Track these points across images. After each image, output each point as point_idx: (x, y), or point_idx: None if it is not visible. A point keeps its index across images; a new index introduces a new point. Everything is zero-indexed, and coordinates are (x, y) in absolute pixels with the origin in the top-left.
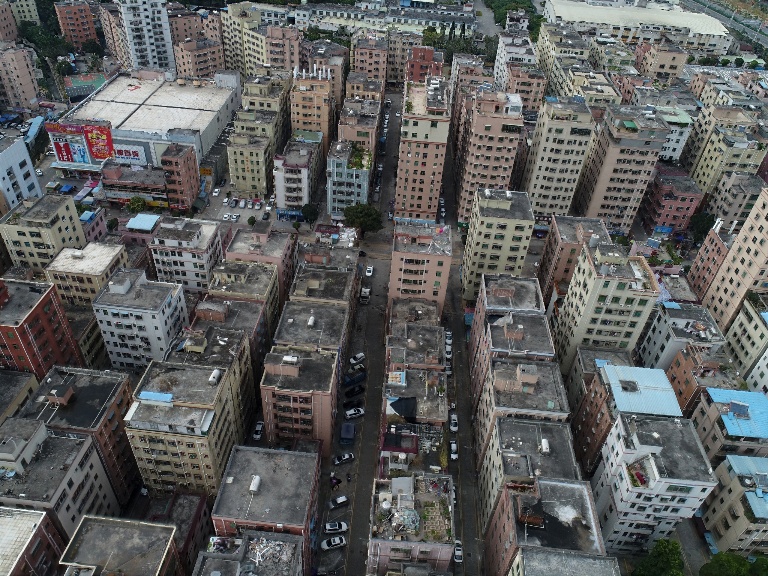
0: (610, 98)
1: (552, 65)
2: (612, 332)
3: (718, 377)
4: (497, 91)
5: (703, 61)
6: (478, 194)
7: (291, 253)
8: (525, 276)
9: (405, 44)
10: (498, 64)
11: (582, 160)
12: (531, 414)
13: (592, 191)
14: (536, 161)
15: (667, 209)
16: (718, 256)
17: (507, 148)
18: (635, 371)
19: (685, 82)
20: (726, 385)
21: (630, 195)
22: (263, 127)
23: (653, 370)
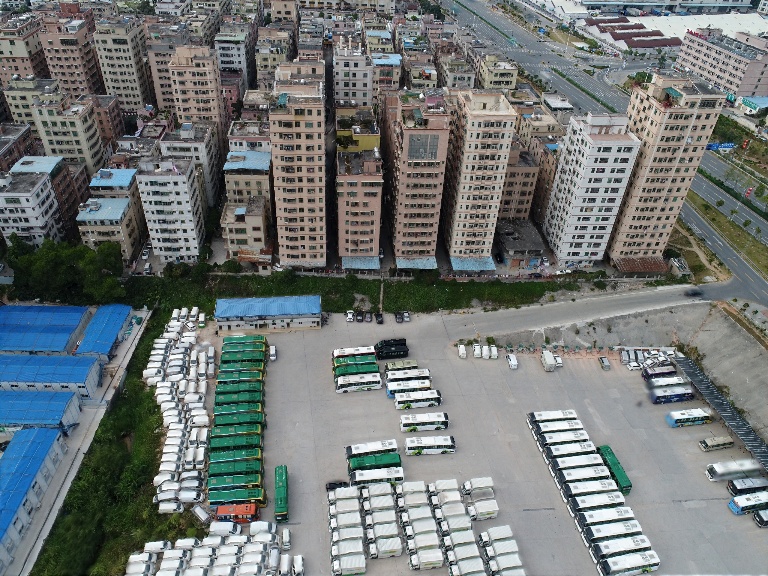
0: (193, 28)
1: None
2: (68, 150)
3: None
4: None
5: None
6: None
7: None
8: None
9: (95, 10)
10: None
11: (132, 64)
12: None
13: None
14: None
15: None
16: None
17: (72, 58)
18: None
19: None
20: None
21: None
22: None
23: (56, 157)
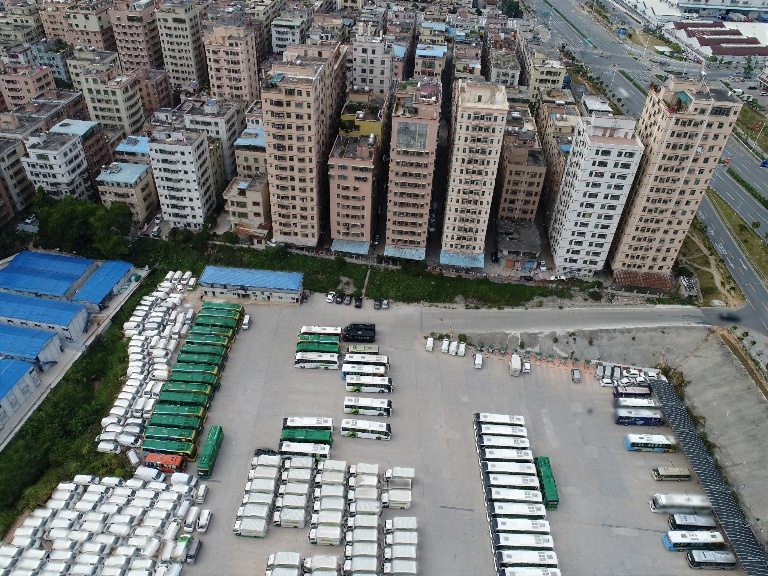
0: (254, 12)
1: None
2: (110, 117)
3: None
4: None
5: (449, 12)
6: None
7: None
8: None
9: None
10: None
11: (189, 42)
12: (4, 137)
13: None
14: None
15: None
16: None
17: (136, 34)
18: (80, 121)
19: None
20: None
21: None
22: (15, 34)
23: None
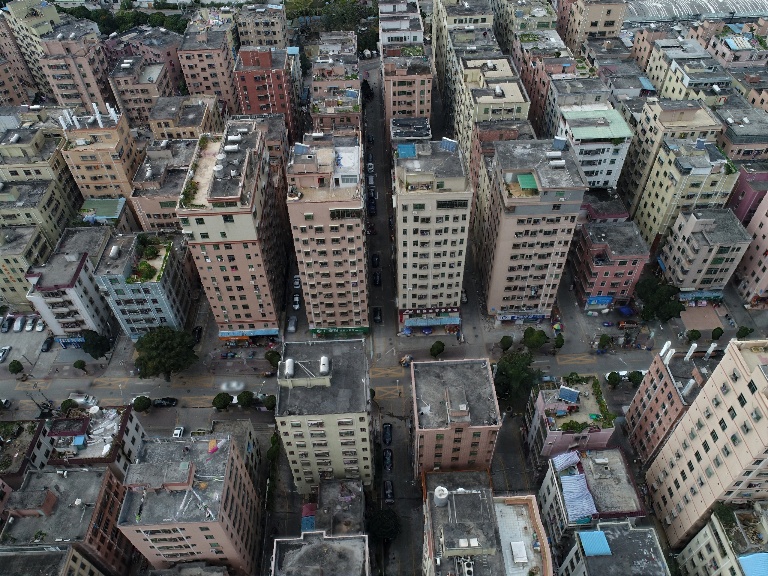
0: (513, 106)
1: (446, 41)
2: None
3: None
4: (324, 147)
5: None
6: (281, 360)
7: (19, 471)
8: (402, 414)
9: (259, 25)
10: (380, 42)
11: (464, 238)
12: None
13: (491, 267)
14: (398, 245)
15: (601, 276)
16: (670, 406)
17: (347, 238)
18: None
19: (632, 26)
20: None
21: (544, 272)
22: (26, 212)
23: None
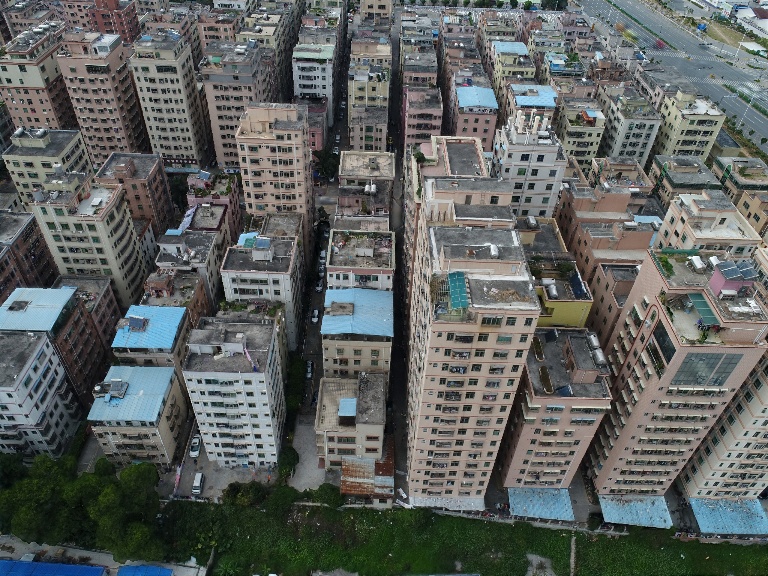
0: (263, 38)
1: None
2: (87, 260)
3: (174, 297)
4: None
5: (478, 3)
6: None
7: None
8: None
9: None
10: None
11: (183, 99)
12: None
13: None
14: None
15: None
16: None
17: (102, 90)
18: (43, 292)
19: (435, 24)
20: (175, 304)
21: None
22: None
23: (63, 290)
